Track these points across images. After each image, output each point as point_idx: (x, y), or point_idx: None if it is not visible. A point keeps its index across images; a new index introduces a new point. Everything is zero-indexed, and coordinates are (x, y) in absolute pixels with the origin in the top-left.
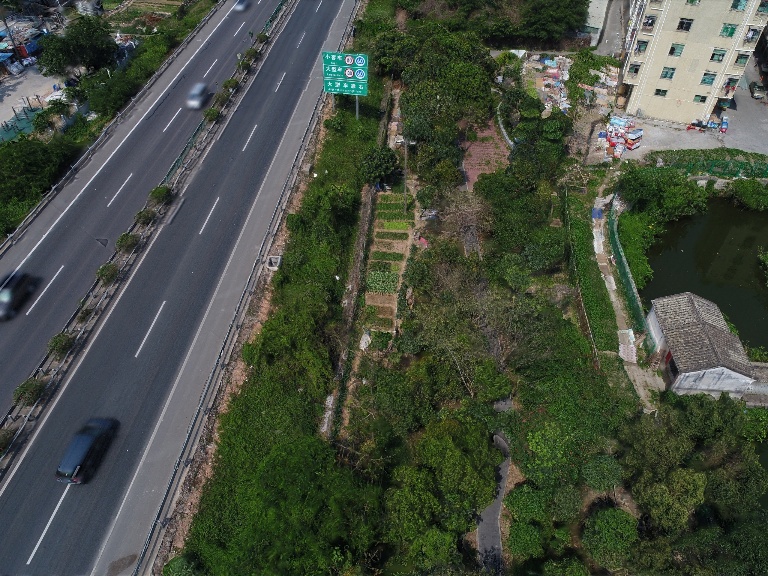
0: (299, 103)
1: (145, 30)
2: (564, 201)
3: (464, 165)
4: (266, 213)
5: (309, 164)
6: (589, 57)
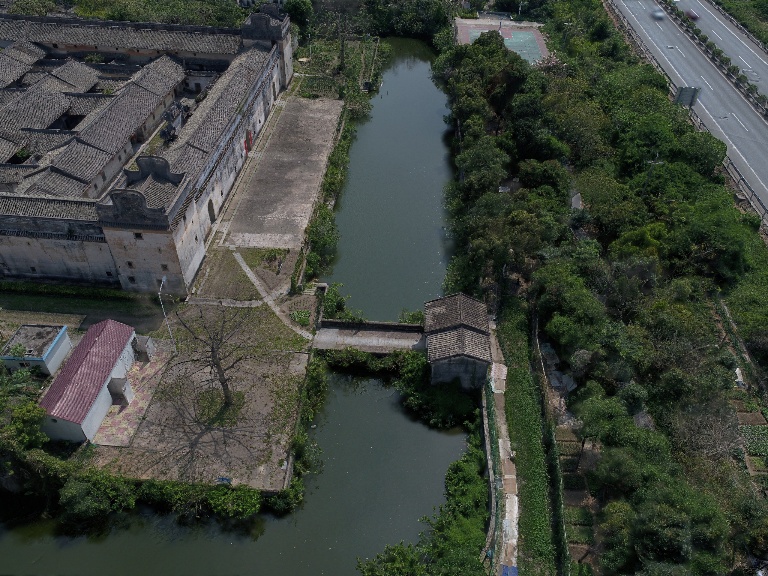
0: None
1: None
2: None
3: None
4: None
5: None
6: None
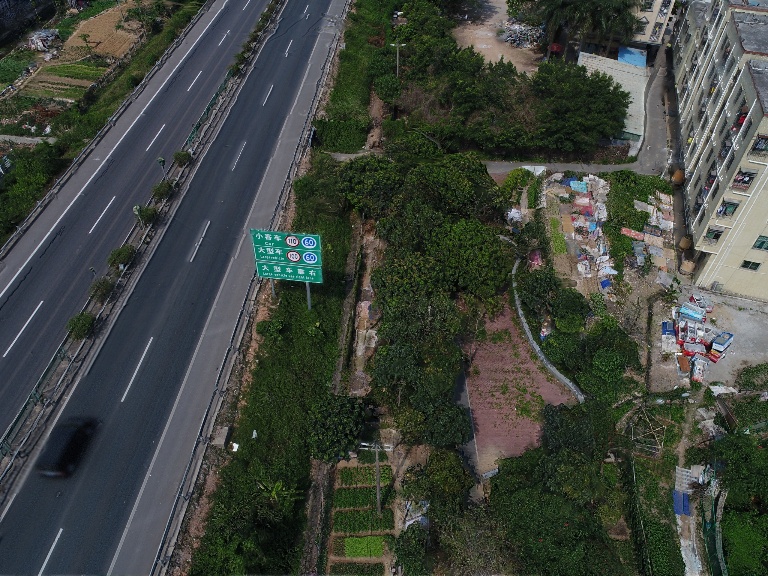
0: (223, 286)
1: (34, 130)
2: (633, 495)
3: (469, 395)
4: (137, 571)
5: (225, 428)
6: (631, 180)
